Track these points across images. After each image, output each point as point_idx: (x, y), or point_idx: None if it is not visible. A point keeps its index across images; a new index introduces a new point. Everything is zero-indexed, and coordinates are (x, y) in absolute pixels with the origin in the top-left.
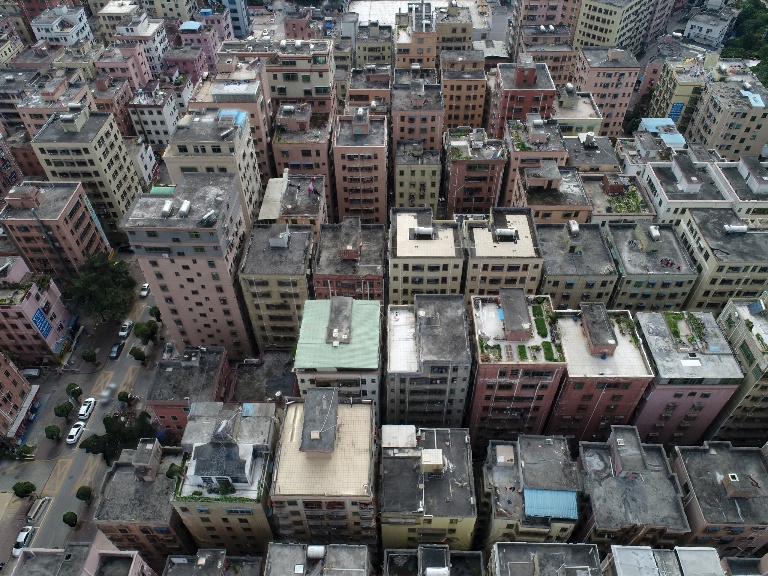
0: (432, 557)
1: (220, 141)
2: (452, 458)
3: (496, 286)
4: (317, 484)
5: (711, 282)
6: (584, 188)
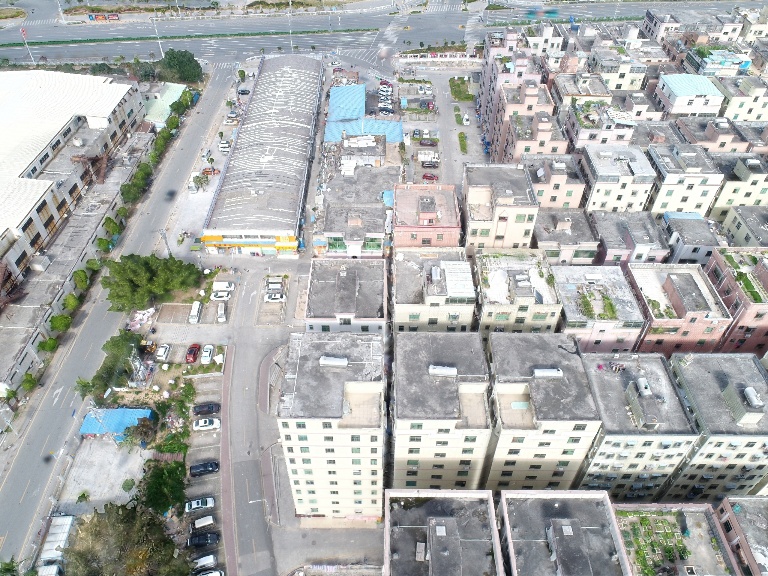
0: (757, 171)
1: None
2: (764, 231)
3: None
4: None
5: None
6: None
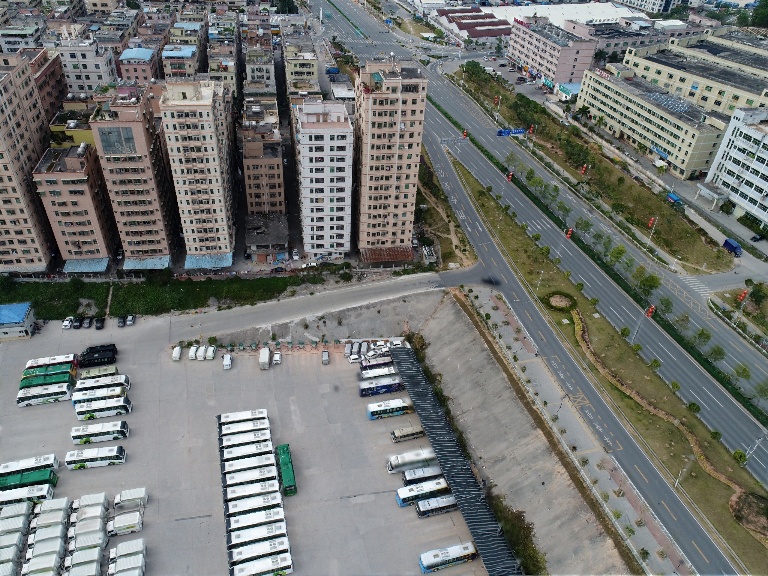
0: None
1: None
2: None
3: (6, 25)
4: None
5: (29, 4)
6: None
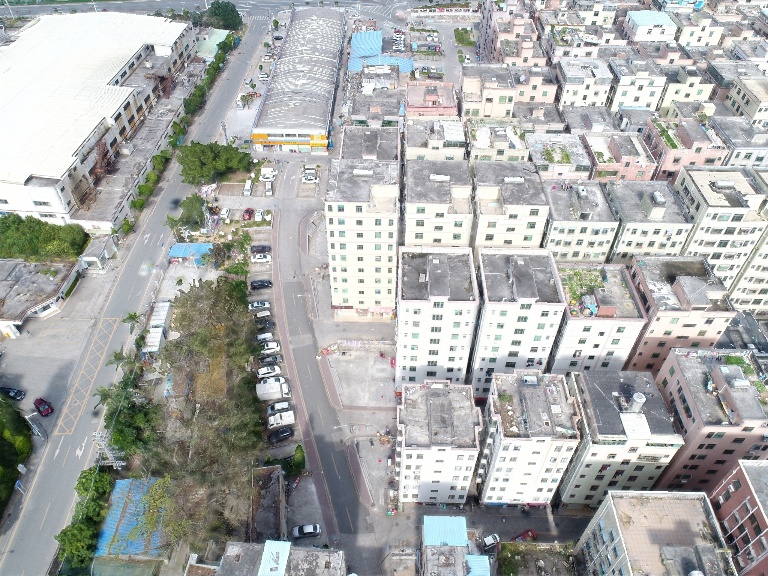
0: (694, 75)
1: None
2: (694, 117)
3: None
4: (765, 82)
5: None
6: (638, 299)
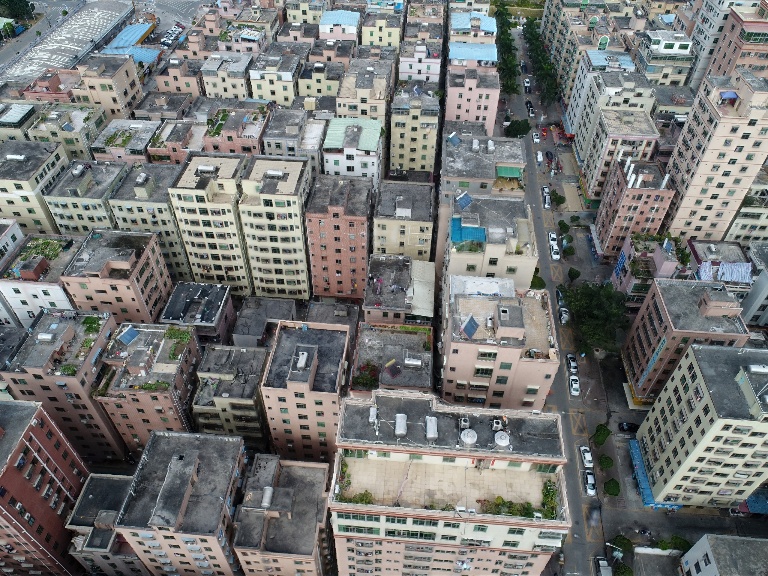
0: None
1: (468, 195)
2: None
3: None
4: None
5: None
6: None
